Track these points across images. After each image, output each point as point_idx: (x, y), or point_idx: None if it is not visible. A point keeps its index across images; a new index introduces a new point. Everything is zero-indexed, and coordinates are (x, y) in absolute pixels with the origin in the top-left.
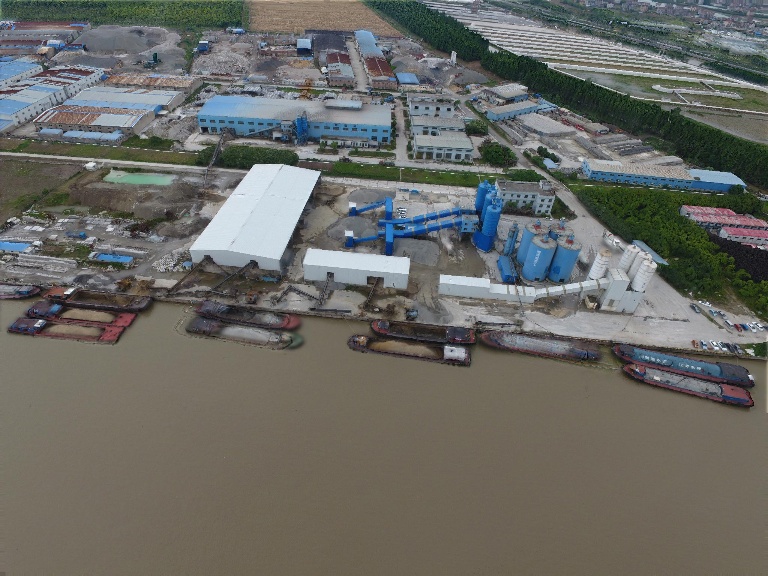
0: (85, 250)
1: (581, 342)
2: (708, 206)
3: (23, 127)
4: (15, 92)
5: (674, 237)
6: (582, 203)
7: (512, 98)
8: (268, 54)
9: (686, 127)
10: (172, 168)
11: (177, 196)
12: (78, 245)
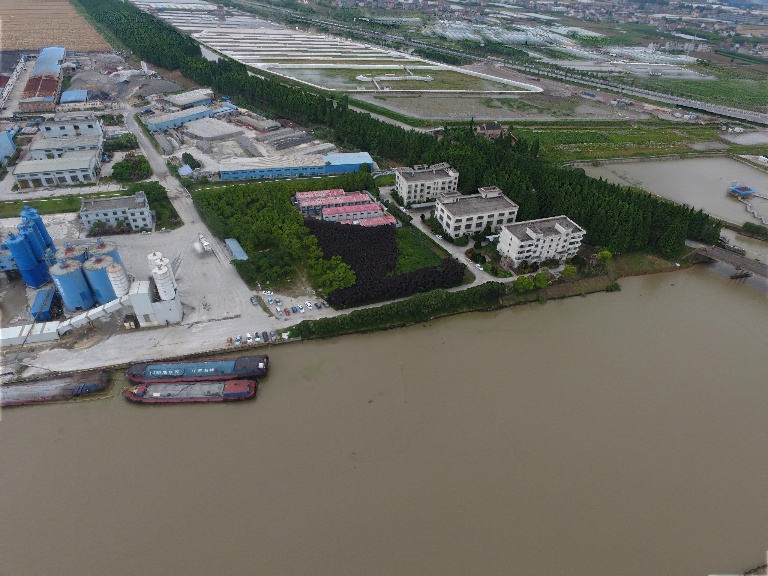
0: None
1: (96, 372)
2: (323, 189)
3: None
4: None
5: (262, 229)
6: (196, 208)
7: (189, 105)
8: None
9: (343, 113)
10: None
11: None
12: None
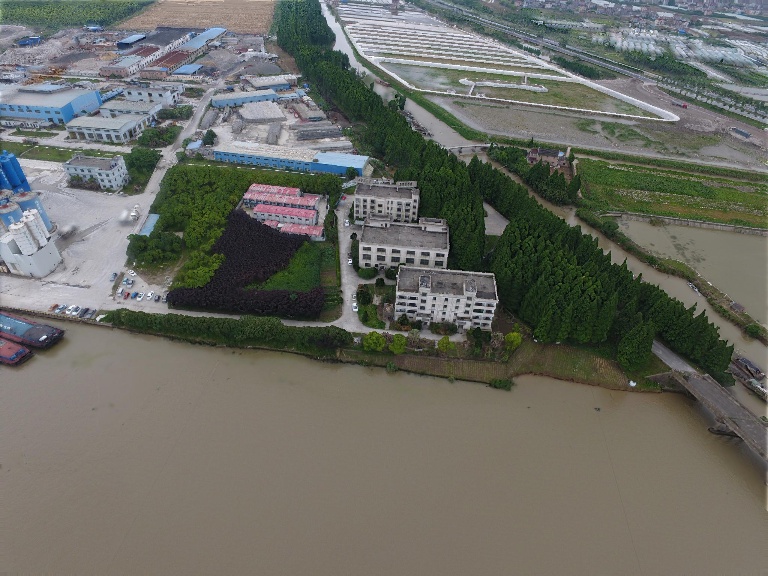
0: None
1: None
2: (282, 185)
3: None
4: None
5: (182, 211)
6: None
7: (265, 87)
8: (89, 48)
9: (382, 113)
10: None
11: None
12: None
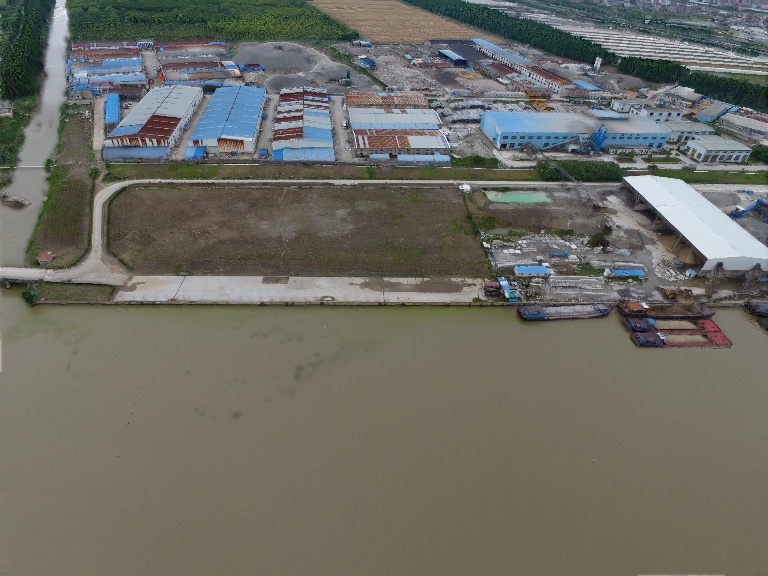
0: (590, 267)
1: None
2: None
3: (338, 153)
4: (301, 118)
5: None
6: None
7: (695, 100)
8: (428, 66)
9: None
10: (530, 185)
11: (588, 211)
12: (571, 263)
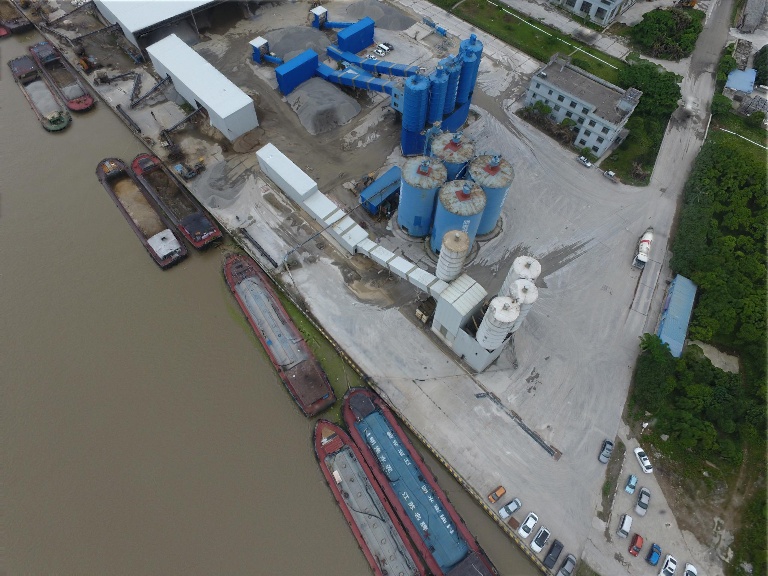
0: None
1: (333, 347)
2: None
3: None
4: None
5: (765, 318)
6: None
7: None
8: None
9: None
10: None
11: None
12: None
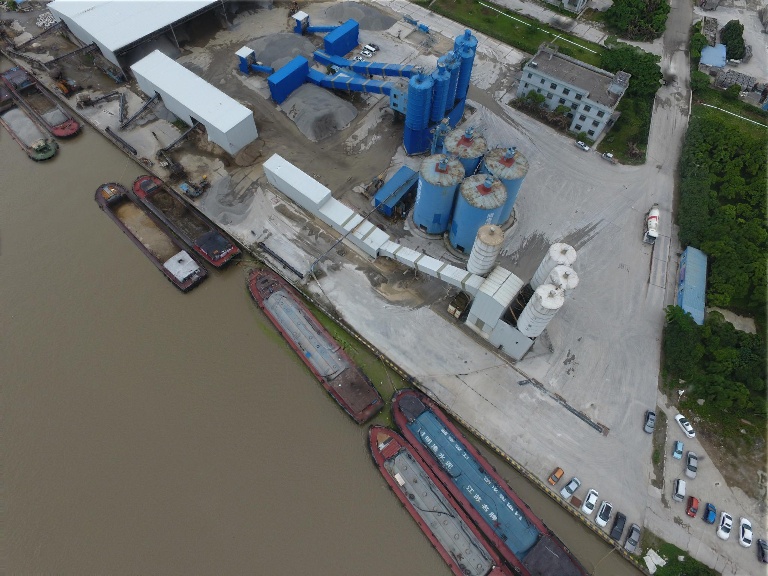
0: None
1: (371, 352)
2: None
3: None
4: None
5: None
6: (683, 144)
7: None
8: None
9: None
10: None
11: None
12: None
